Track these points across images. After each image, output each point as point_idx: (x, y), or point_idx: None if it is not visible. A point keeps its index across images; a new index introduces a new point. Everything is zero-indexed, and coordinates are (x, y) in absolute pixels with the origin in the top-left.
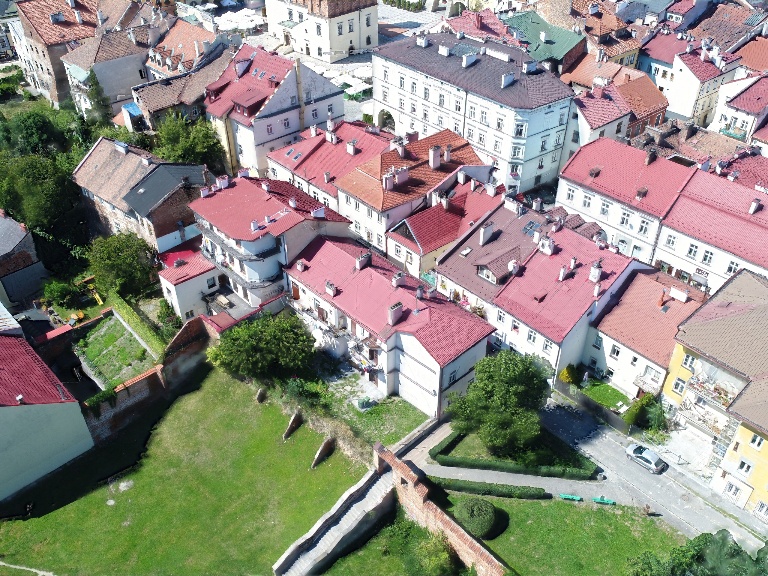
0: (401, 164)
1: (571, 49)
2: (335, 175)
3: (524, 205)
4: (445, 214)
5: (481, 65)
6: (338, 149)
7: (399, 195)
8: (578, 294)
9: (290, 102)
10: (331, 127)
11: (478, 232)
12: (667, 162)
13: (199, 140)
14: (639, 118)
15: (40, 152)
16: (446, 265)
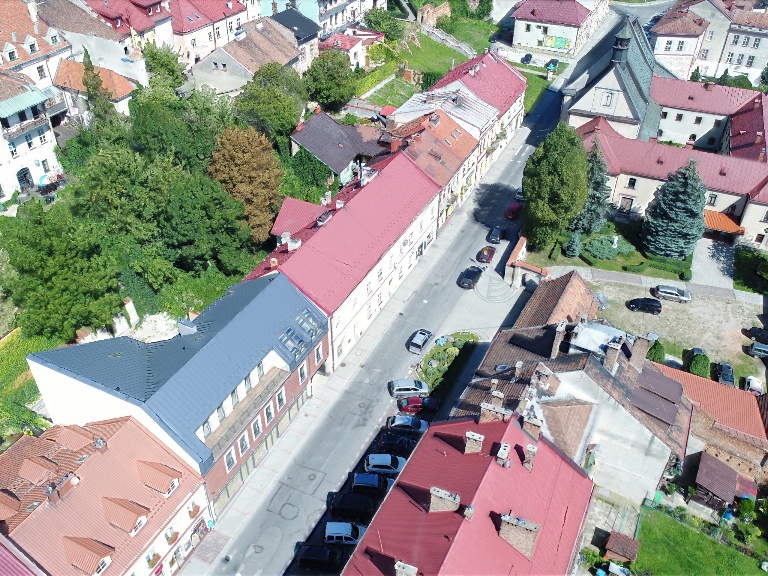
0: None
1: None
2: (225, 4)
3: None
4: None
5: None
6: None
7: None
8: None
9: None
10: None
11: None
12: None
13: None
14: None
15: None
16: None
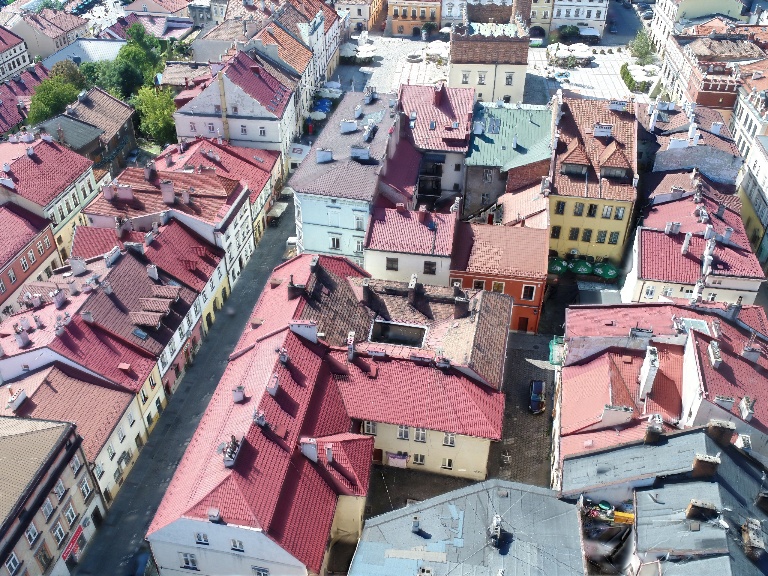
0: (141, 184)
1: (523, 166)
2: None
3: (157, 268)
4: (116, 241)
5: (353, 136)
6: (175, 158)
7: (111, 207)
8: (8, 348)
9: (214, 109)
10: (218, 142)
11: (91, 264)
12: (294, 306)
13: (162, 117)
14: (470, 271)
15: (107, 89)
16: (54, 277)
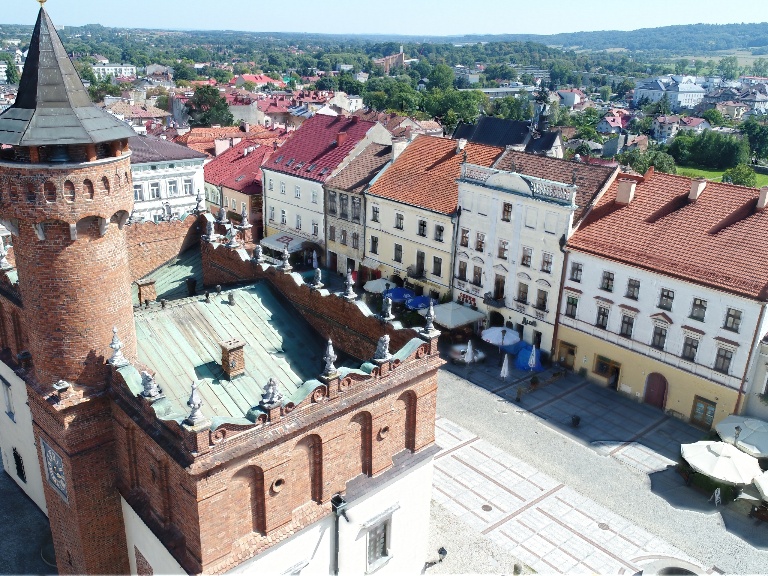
0: None
1: None
2: None
3: None
4: None
5: None
6: None
7: None
8: None
9: None
10: None
11: None
12: None
13: None
14: None
15: None
16: None
